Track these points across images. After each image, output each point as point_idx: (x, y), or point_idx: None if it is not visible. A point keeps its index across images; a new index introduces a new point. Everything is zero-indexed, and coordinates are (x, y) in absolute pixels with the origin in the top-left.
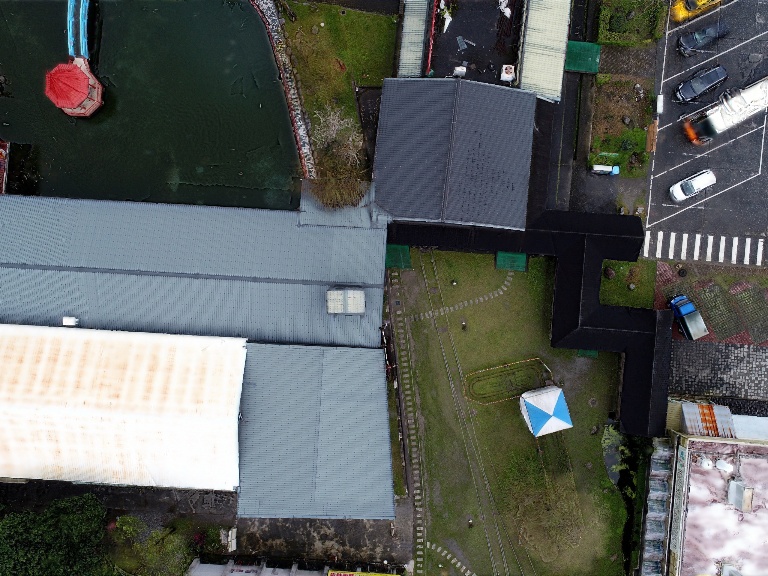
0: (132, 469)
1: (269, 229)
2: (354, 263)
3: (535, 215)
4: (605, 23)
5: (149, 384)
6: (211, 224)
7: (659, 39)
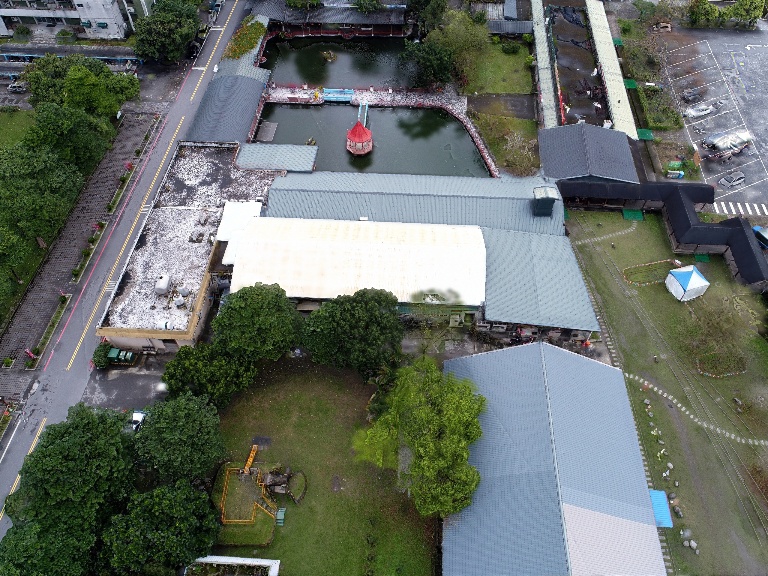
0: (409, 289)
1: (484, 183)
2: None
3: (643, 181)
4: (651, 119)
5: (423, 238)
6: (449, 181)
7: (682, 128)
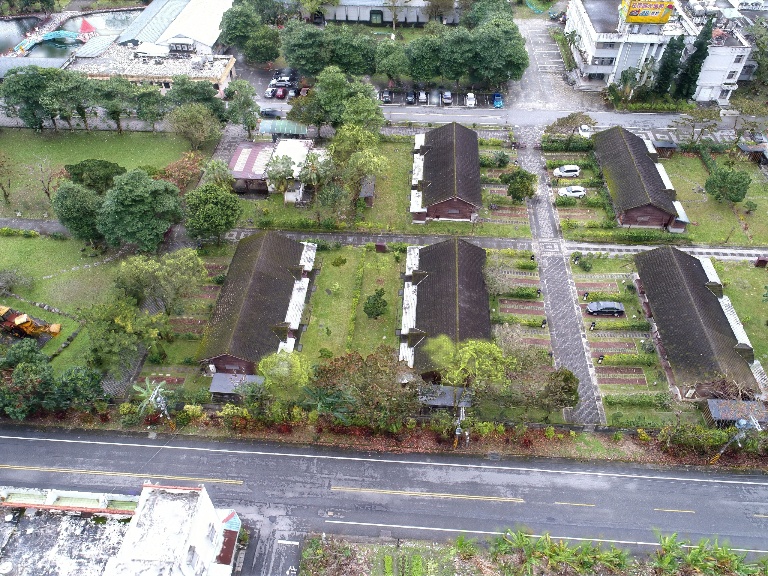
0: (230, 7)
1: None
2: None
3: None
4: None
5: None
6: None
7: None
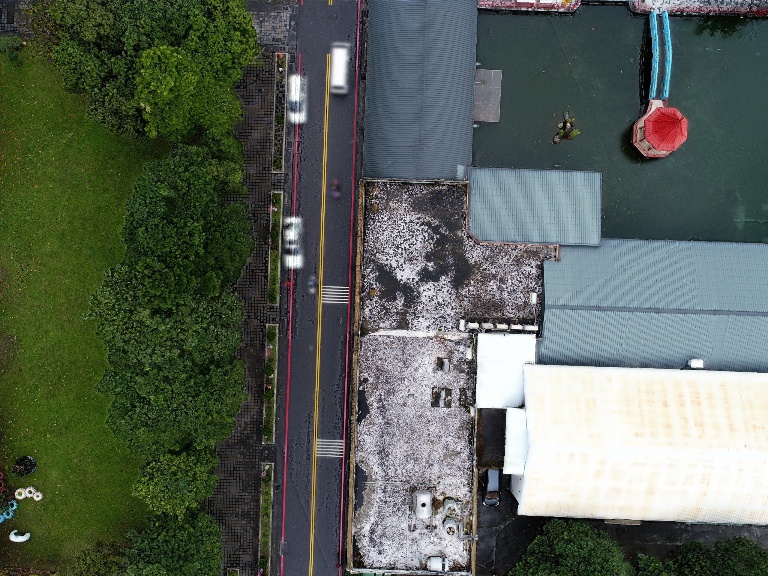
0: None
1: None
2: None
3: None
4: None
5: None
6: None
7: None
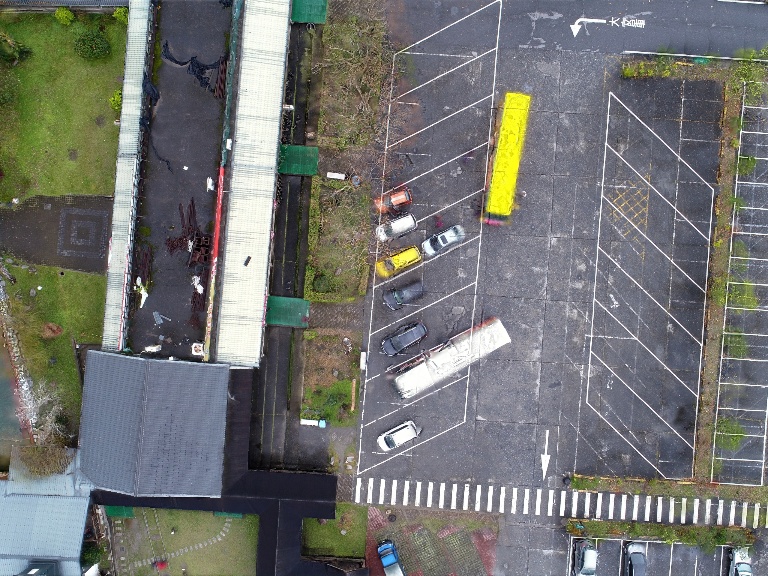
0: None
1: None
2: (53, 535)
3: (234, 479)
4: (309, 283)
5: None
6: None
7: (366, 294)
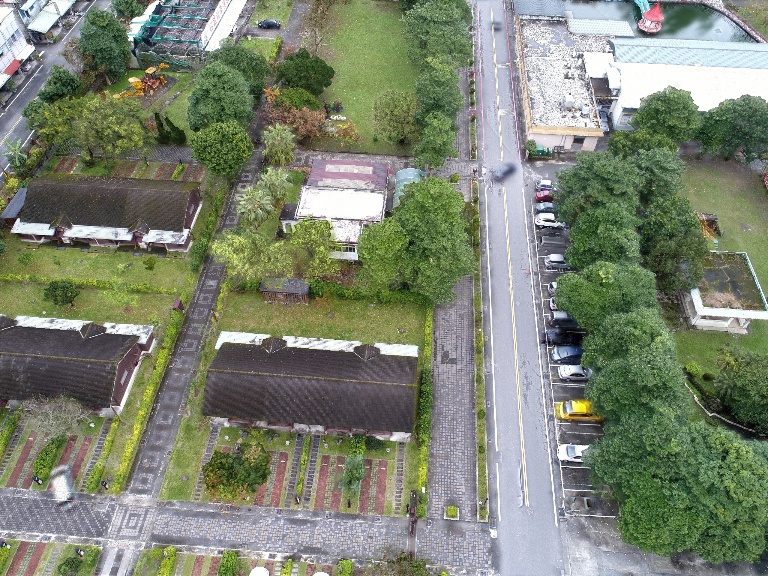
0: None
1: None
2: None
3: None
4: None
5: (759, 73)
6: (748, 44)
7: None
